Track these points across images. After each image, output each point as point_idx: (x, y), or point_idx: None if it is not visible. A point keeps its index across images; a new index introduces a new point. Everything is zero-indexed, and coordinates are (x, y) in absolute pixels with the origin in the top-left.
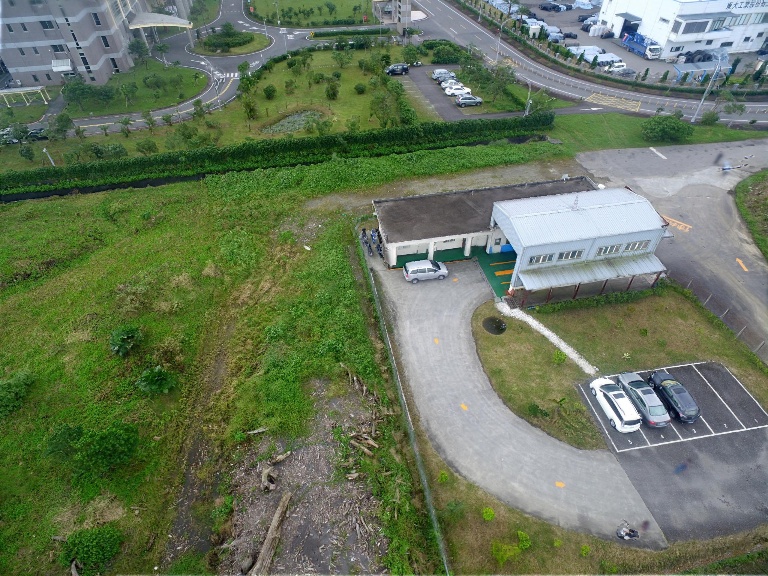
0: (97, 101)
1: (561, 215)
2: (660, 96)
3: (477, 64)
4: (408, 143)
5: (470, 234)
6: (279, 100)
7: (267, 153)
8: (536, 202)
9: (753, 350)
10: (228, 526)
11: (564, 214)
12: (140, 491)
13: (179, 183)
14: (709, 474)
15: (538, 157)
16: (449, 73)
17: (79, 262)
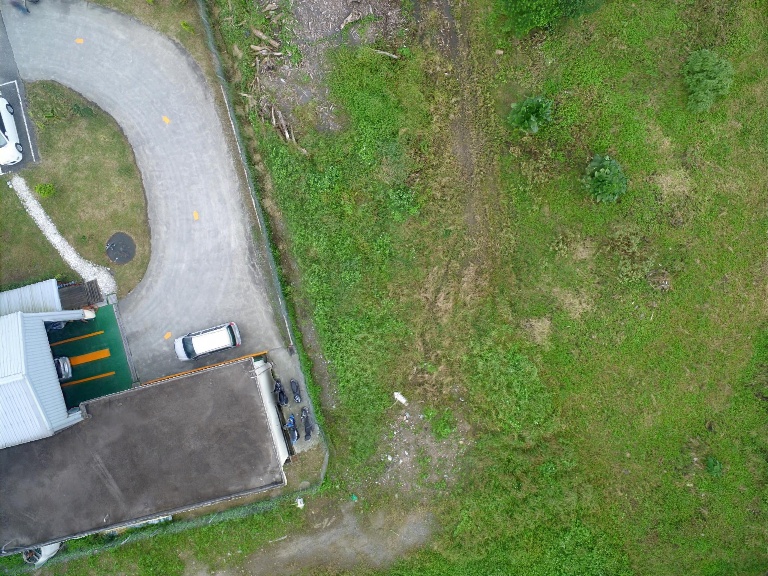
0: None
1: None
2: None
3: None
4: None
5: (119, 393)
6: None
7: None
8: None
9: None
10: None
11: None
12: None
13: None
14: None
15: None
16: None
17: (767, 339)
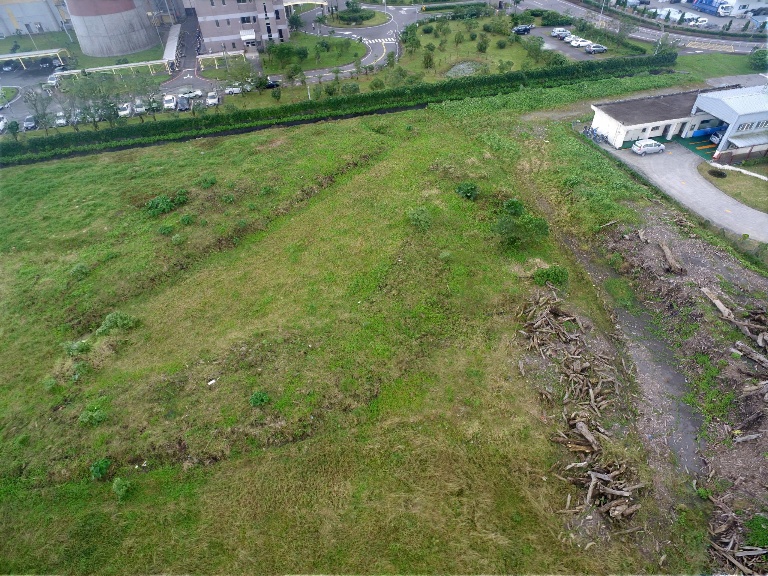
0: (288, 61)
1: (756, 96)
2: (745, 41)
3: (588, 23)
4: (570, 78)
5: (680, 119)
6: (438, 55)
7: (467, 87)
8: (730, 92)
9: None
10: (627, 264)
11: (757, 96)
12: (550, 257)
13: (409, 110)
14: None
15: (678, 83)
16: (566, 31)
17: (384, 156)
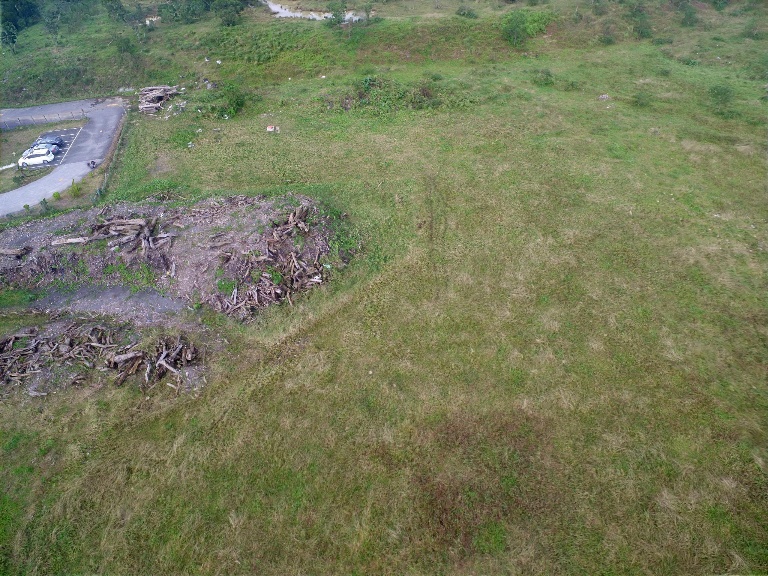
0: None
1: None
2: None
3: None
4: None
5: None
6: None
7: None
8: None
9: (46, 123)
10: None
11: None
12: None
13: None
14: (87, 145)
15: None
16: None
17: None
